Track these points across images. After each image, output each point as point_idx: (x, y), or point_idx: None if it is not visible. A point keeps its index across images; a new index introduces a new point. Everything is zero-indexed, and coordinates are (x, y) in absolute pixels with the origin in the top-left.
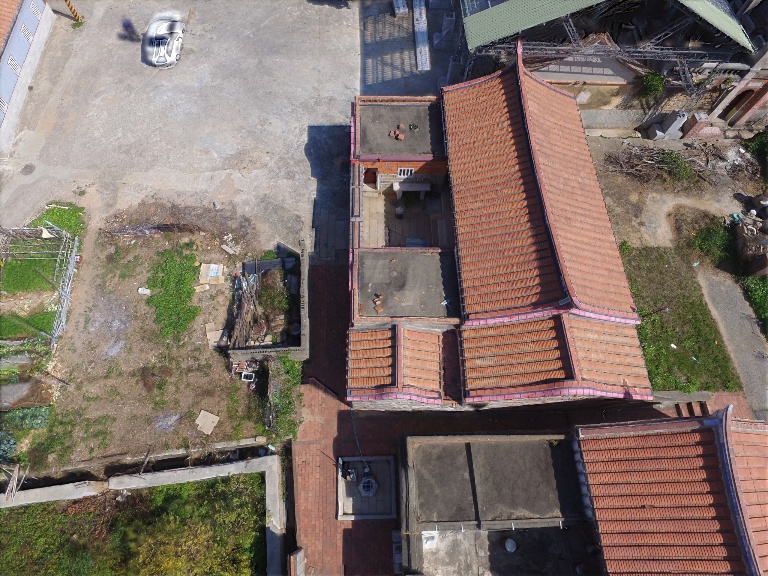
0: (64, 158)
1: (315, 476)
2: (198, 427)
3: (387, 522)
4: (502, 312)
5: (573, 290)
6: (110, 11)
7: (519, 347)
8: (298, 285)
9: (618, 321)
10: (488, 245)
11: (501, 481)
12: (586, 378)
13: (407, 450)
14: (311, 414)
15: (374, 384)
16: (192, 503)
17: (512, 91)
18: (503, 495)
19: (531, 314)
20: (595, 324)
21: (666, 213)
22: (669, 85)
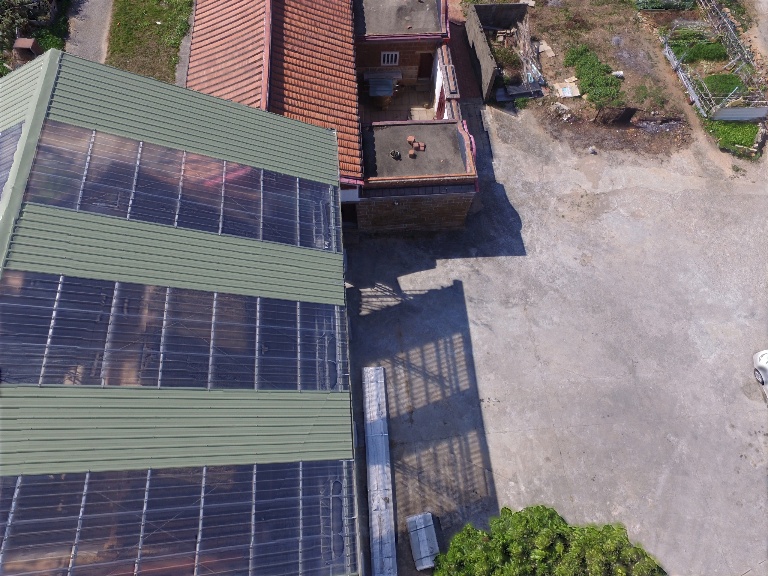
0: None
1: None
2: None
3: None
4: None
5: None
6: None
7: None
8: None
9: None
10: (325, 4)
11: None
12: None
13: None
14: (455, 7)
15: None
16: None
17: None
18: None
19: None
20: None
21: None
22: None
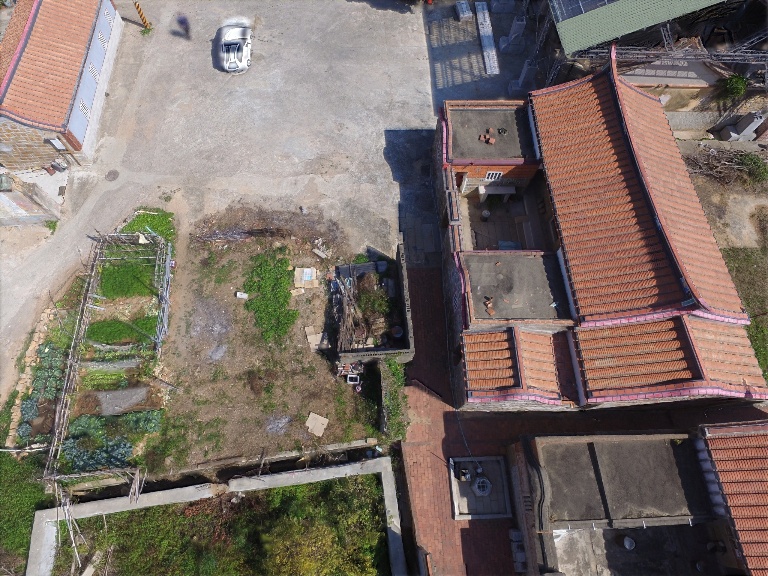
0: (147, 164)
1: (428, 477)
2: (309, 429)
3: (503, 521)
4: (620, 314)
5: (697, 292)
6: (177, 17)
7: (639, 348)
8: (395, 288)
9: (731, 322)
10: (596, 248)
11: (627, 480)
12: (711, 378)
13: (537, 450)
14: (417, 415)
15: (495, 386)
16: (308, 504)
17: (606, 95)
18: (631, 494)
19: (650, 315)
20: (710, 325)
21: (749, 214)
22: (750, 88)
